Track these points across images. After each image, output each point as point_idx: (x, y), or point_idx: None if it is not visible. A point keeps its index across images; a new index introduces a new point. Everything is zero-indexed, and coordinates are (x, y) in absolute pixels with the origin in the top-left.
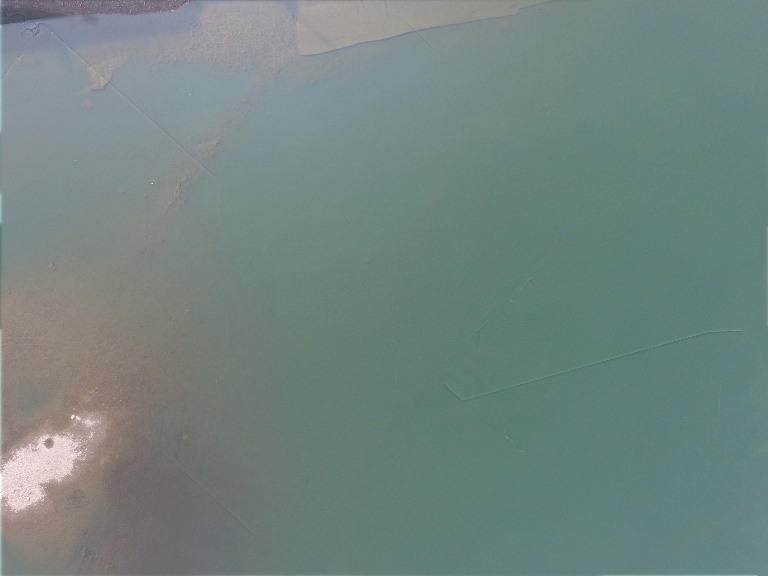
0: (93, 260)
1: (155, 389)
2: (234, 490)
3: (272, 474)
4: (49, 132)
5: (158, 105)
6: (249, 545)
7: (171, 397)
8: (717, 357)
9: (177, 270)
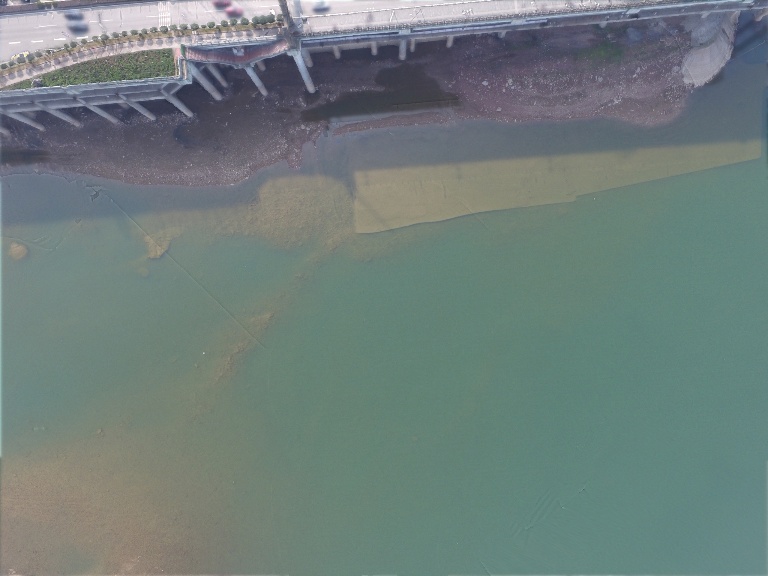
0: (141, 427)
1: (197, 560)
2: None
3: None
4: (103, 296)
5: (213, 276)
6: None
7: (213, 568)
8: None
9: (225, 441)
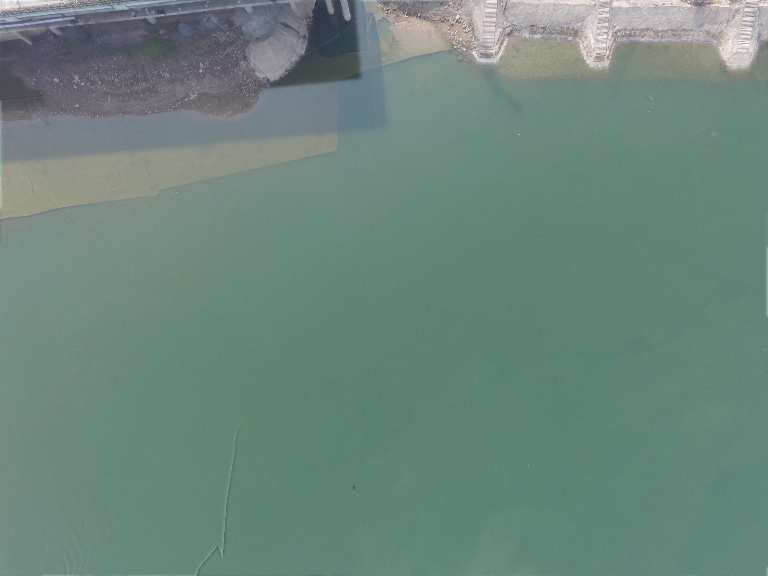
0: None
1: None
2: None
3: None
4: None
5: None
6: None
7: None
8: (354, 534)
9: None
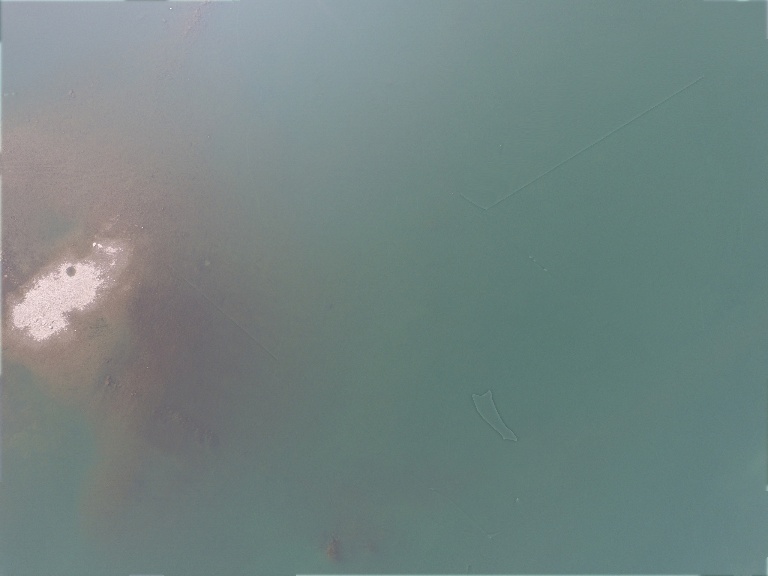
0: (112, 87)
1: (177, 216)
2: (257, 317)
3: (295, 301)
4: None
5: None
6: (273, 371)
7: (193, 224)
8: (739, 181)
9: (197, 96)
